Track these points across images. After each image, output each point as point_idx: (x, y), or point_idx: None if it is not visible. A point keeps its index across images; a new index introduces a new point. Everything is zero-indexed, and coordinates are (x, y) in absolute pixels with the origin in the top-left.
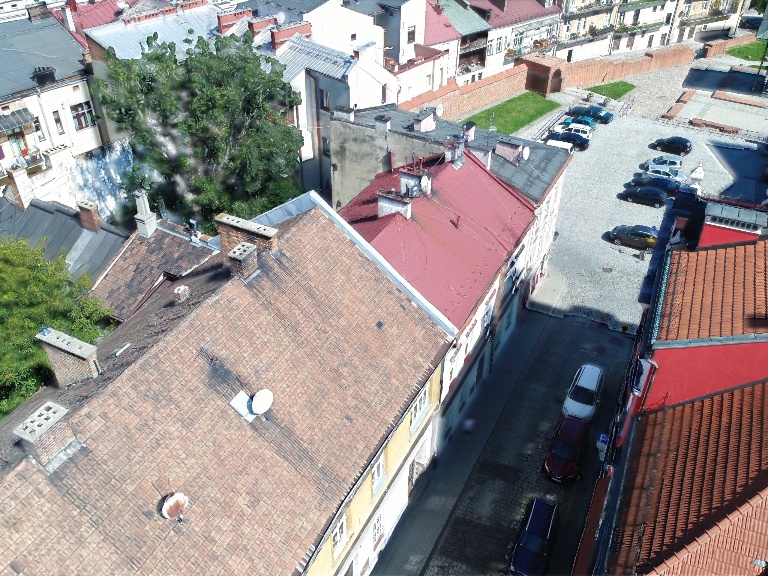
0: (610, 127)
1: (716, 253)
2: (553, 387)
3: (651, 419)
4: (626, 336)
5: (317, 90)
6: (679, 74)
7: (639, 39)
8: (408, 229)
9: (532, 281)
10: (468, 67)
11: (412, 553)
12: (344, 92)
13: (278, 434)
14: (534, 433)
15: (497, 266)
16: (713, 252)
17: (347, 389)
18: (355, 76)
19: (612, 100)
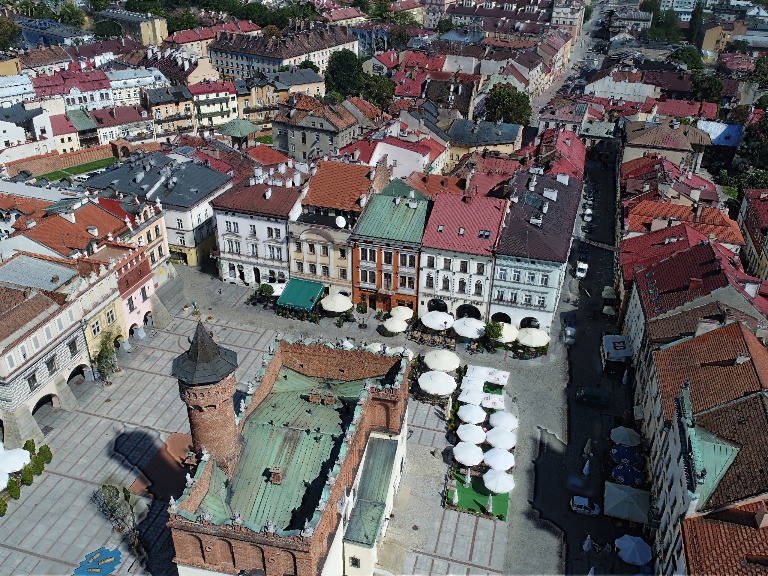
0: None
1: None
2: None
3: None
4: None
5: None
6: None
7: None
8: None
9: None
10: (90, 145)
11: None
12: None
13: None
14: None
15: None
16: None
17: None
18: None
19: None
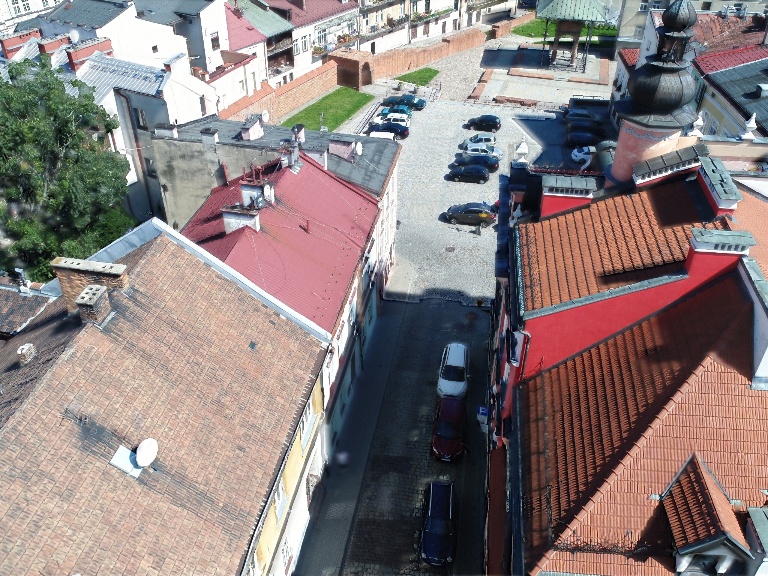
0: (425, 113)
1: (558, 221)
2: (424, 371)
3: (531, 386)
4: (480, 309)
5: (130, 109)
6: (475, 56)
7: (433, 26)
8: (260, 242)
9: (384, 272)
10: (278, 69)
11: (324, 567)
12: (161, 108)
13: (170, 483)
14: (416, 419)
15: (354, 264)
16: (555, 220)
17: (233, 419)
18: (170, 90)
19: (421, 87)
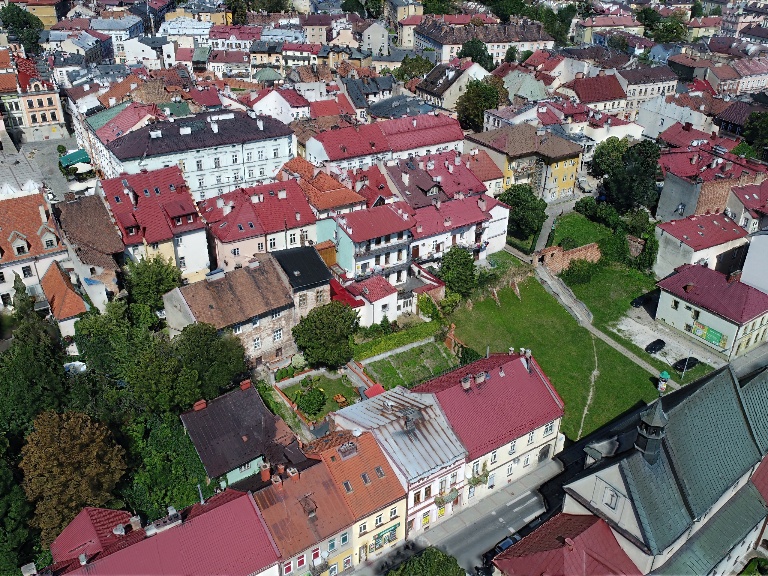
0: None
1: None
2: None
3: None
4: None
5: None
6: None
7: None
8: None
9: None
10: None
11: None
12: None
13: None
14: None
15: None
16: None
17: None
18: (64, 44)
19: None
